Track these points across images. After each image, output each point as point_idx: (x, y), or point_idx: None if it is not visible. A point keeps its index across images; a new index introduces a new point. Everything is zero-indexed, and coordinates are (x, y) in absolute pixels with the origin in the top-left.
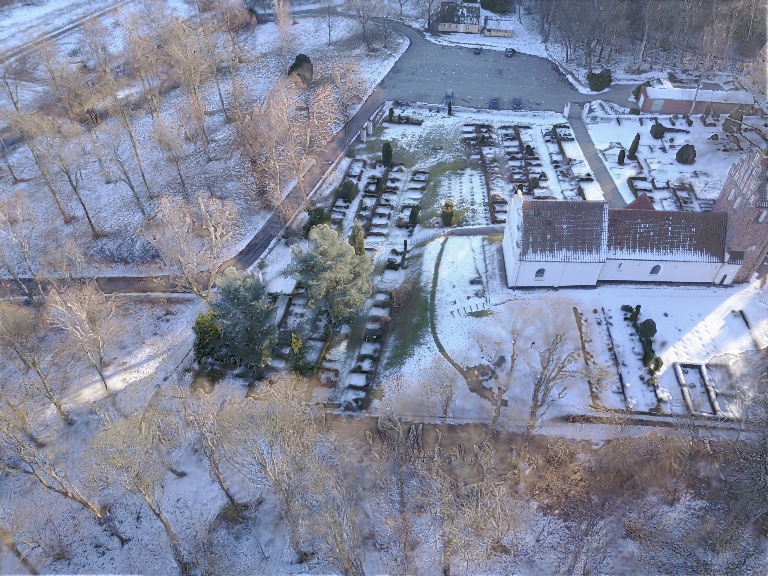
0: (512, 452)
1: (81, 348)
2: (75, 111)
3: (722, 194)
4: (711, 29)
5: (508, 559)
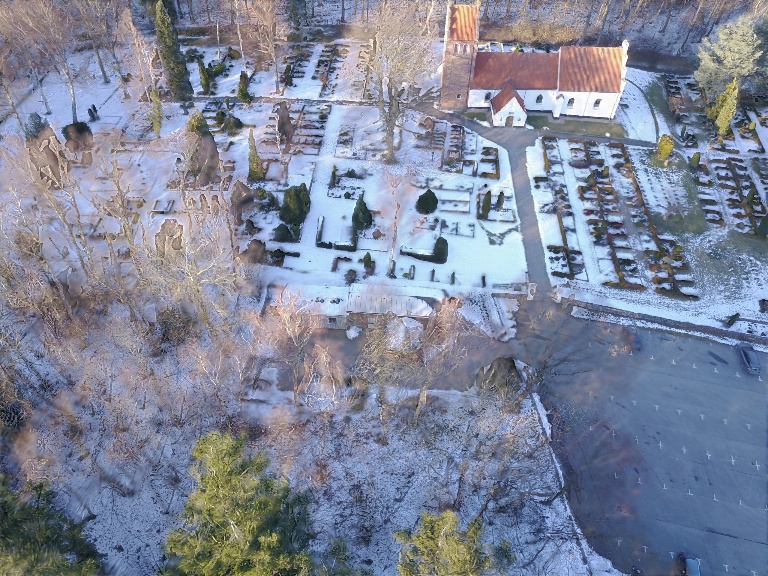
0: None
1: None
2: None
3: (476, 53)
4: None
5: None
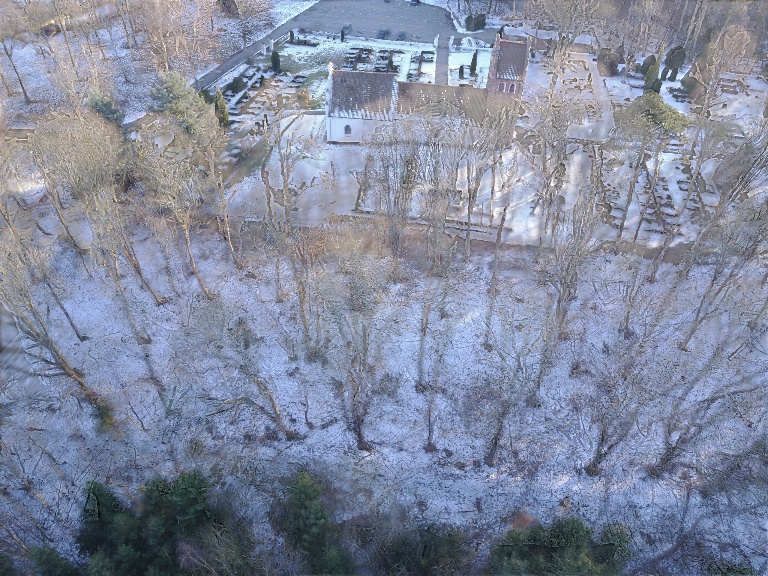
0: (284, 231)
1: None
2: None
3: (488, 76)
4: None
5: (253, 281)
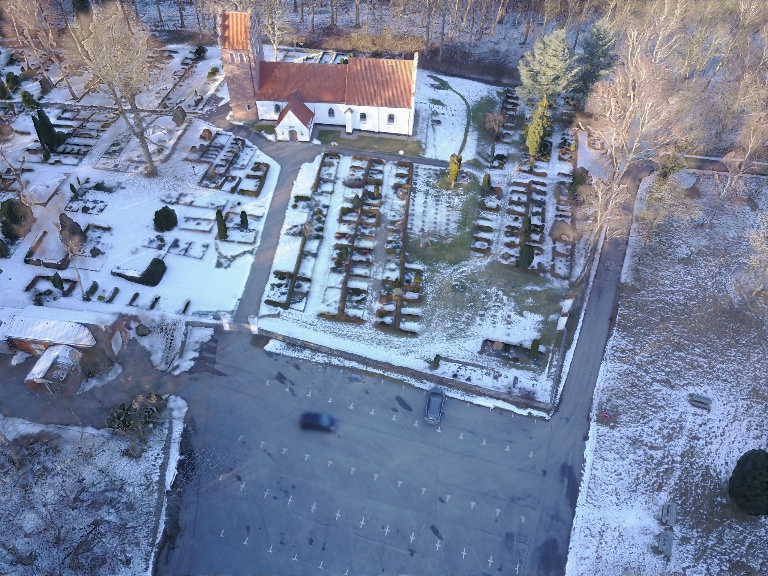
0: None
1: None
2: None
3: (255, 62)
4: None
5: None
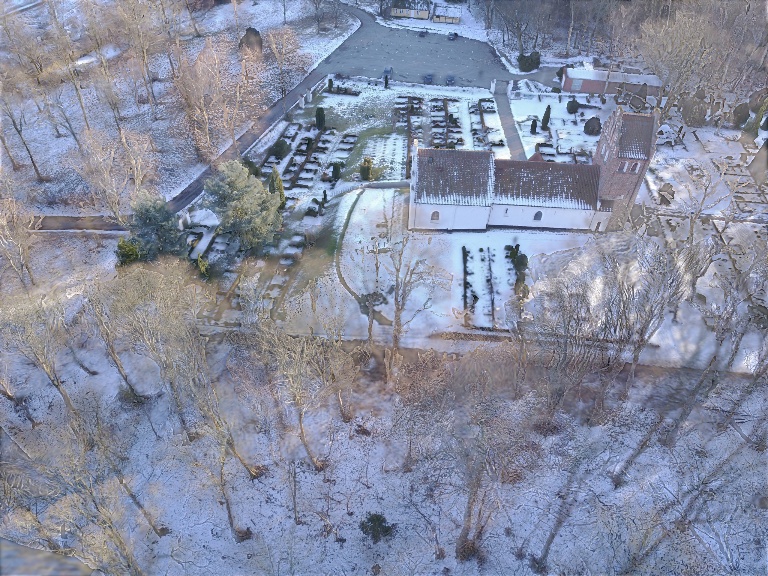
0: None
1: (4, 255)
2: (25, 64)
3: (598, 150)
4: (643, 22)
5: (367, 439)
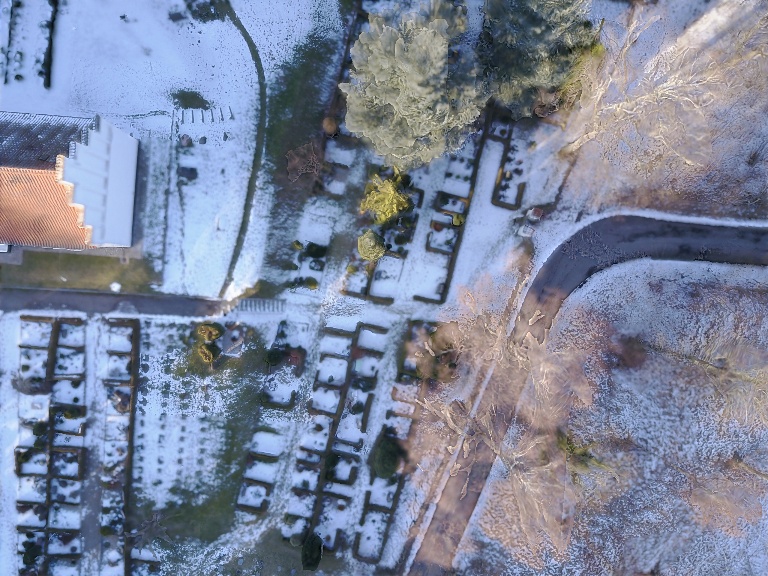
0: None
1: None
2: None
3: None
4: None
5: None
